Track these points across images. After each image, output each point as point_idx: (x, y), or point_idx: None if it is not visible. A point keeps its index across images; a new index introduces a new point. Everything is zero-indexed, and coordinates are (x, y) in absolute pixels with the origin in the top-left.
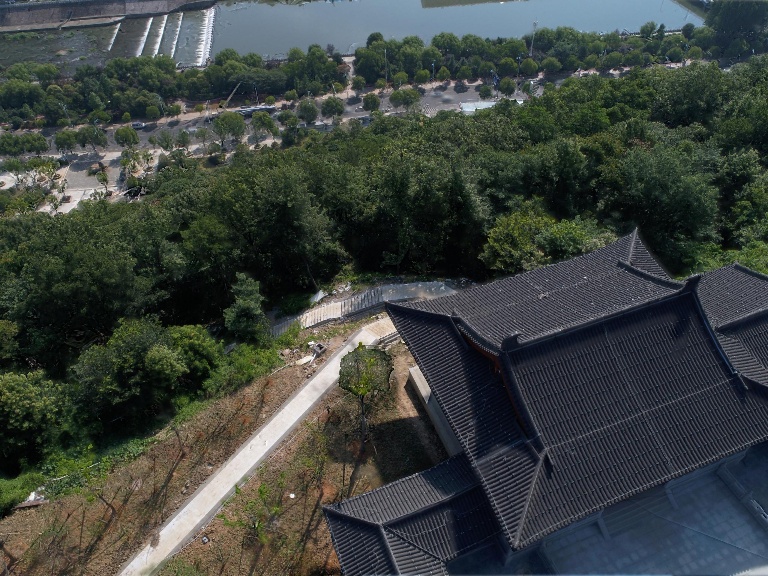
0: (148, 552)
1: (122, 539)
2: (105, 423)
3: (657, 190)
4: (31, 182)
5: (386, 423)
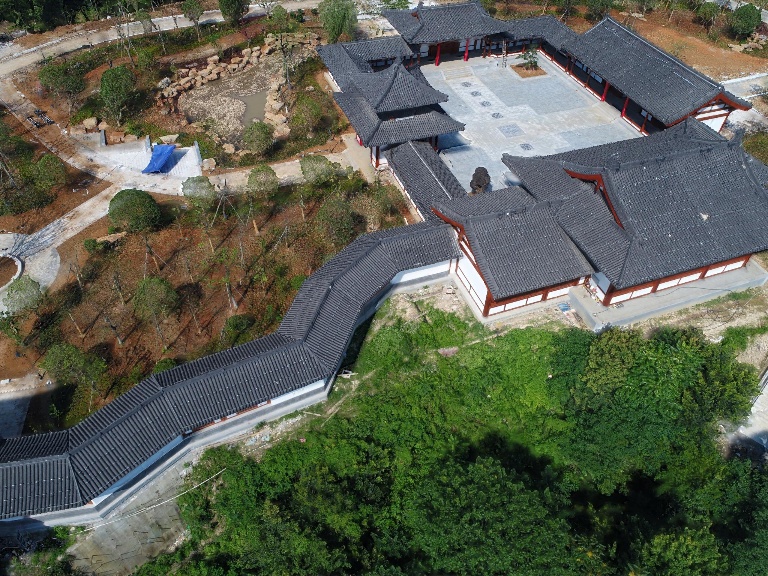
0: None
1: None
2: None
3: None
4: None
5: (765, 250)
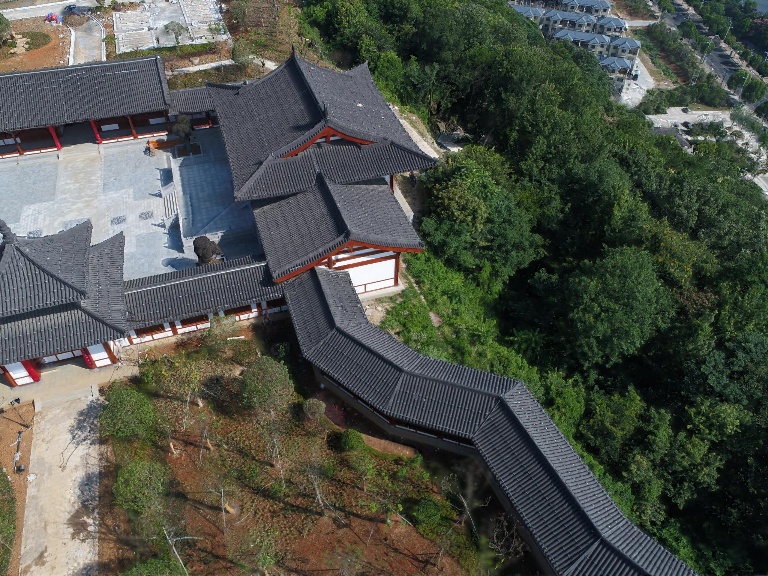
0: (273, 64)
1: (280, 57)
2: (345, 54)
3: (587, 276)
4: (757, 158)
5: None
